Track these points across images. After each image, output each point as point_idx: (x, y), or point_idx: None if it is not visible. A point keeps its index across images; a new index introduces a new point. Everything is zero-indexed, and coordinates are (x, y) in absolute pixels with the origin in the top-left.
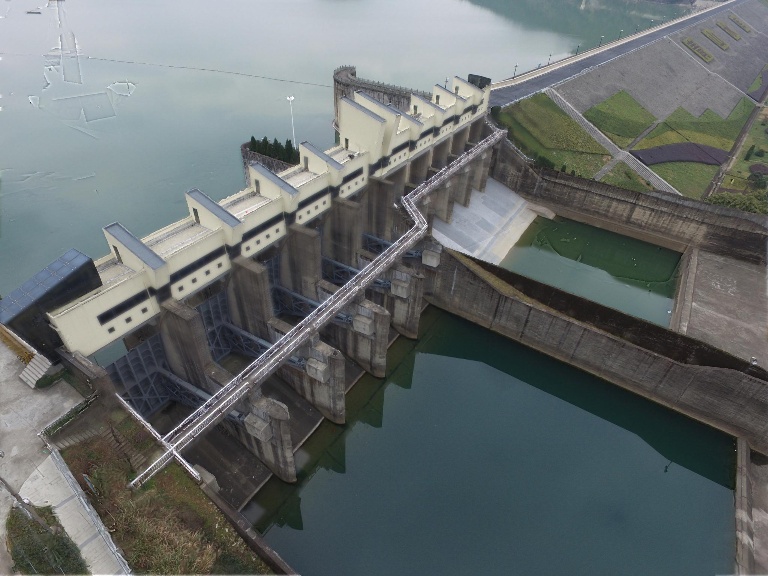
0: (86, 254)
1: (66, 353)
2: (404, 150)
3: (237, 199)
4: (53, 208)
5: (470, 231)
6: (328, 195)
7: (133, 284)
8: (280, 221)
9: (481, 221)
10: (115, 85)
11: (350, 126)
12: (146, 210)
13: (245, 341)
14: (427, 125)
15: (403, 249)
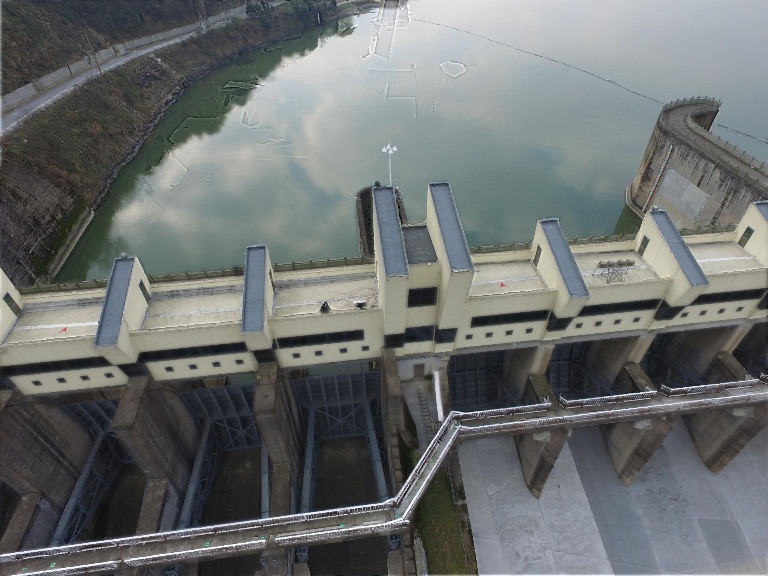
0: (194, 242)
1: None
2: (528, 323)
3: (94, 298)
4: (240, 181)
5: (665, 529)
6: (249, 354)
7: None
8: (114, 365)
9: (722, 524)
10: (447, 64)
11: (376, 246)
12: (291, 216)
13: None
14: (634, 292)
15: (299, 539)
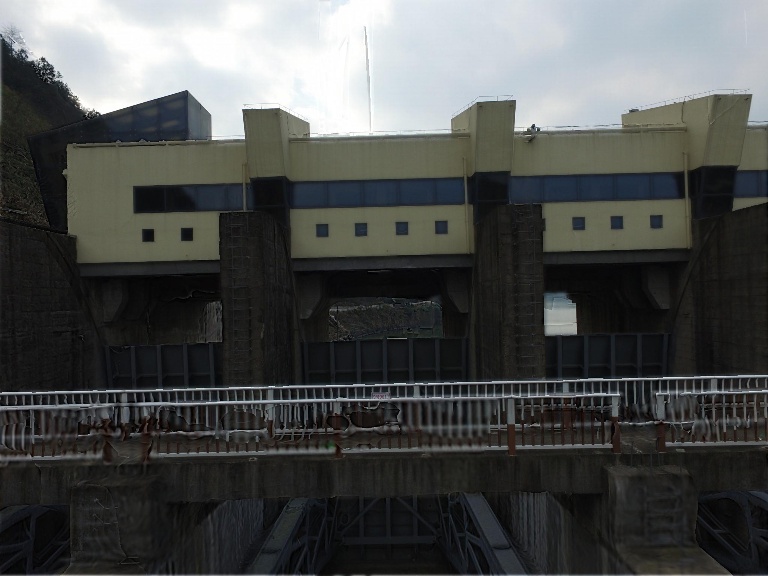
0: None
1: (59, 229)
2: None
3: None
4: None
5: None
6: None
7: (223, 158)
8: (671, 198)
9: None
10: None
11: None
12: None
13: (454, 499)
14: None
15: None
